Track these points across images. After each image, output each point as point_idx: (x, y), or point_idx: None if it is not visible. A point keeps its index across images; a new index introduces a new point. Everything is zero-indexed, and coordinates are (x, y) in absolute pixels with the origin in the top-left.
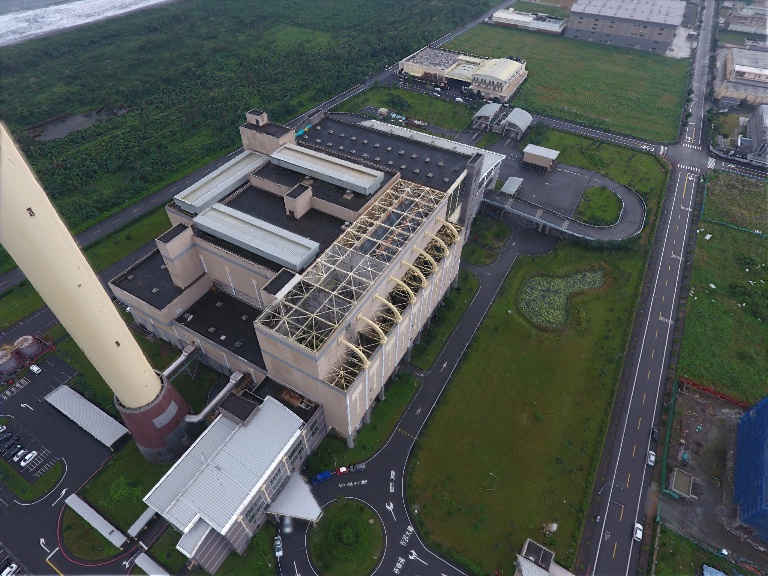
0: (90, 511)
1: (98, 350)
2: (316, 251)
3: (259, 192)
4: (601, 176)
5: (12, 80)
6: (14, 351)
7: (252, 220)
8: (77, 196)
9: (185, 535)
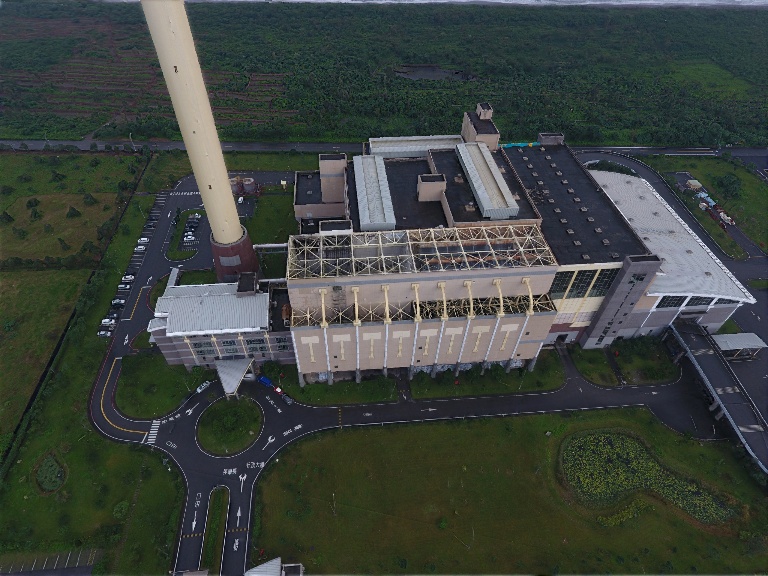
0: (173, 282)
1: (199, 183)
2: (390, 227)
3: (425, 168)
4: None
5: (432, 29)
6: (240, 182)
7: (382, 179)
8: (373, 120)
9: (158, 319)
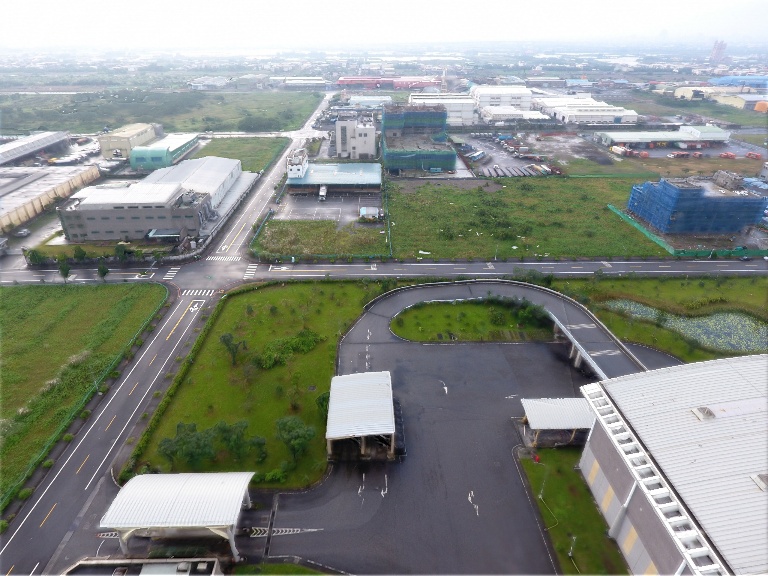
0: None
1: None
2: None
3: None
4: (351, 333)
5: None
6: None
7: None
8: None
9: None
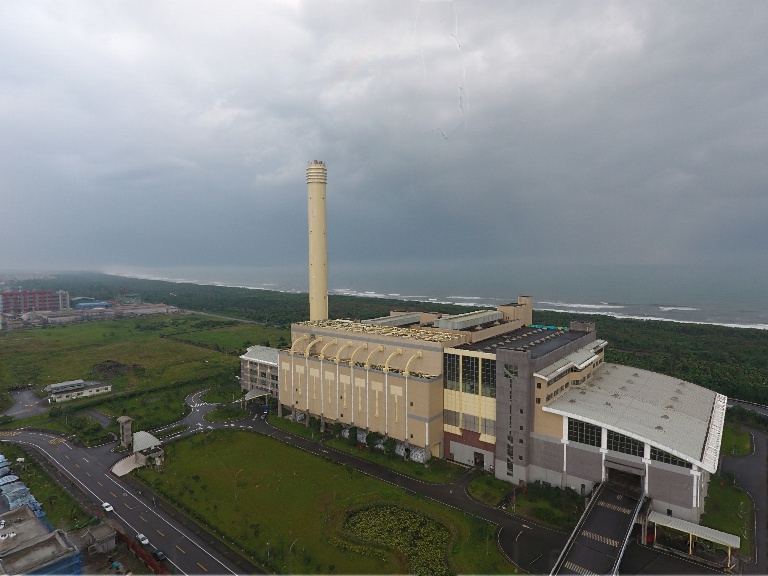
0: None
1: None
2: None
3: None
4: None
5: None
6: None
7: (409, 316)
8: None
9: None
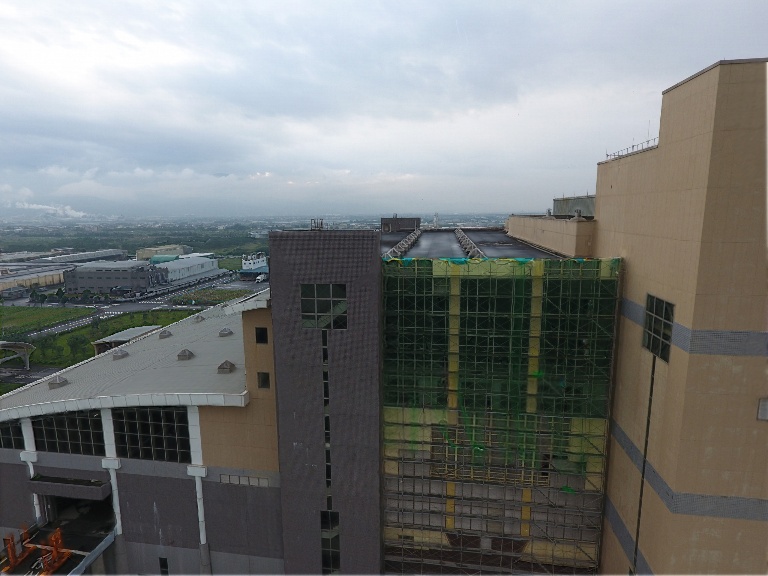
0: None
1: None
2: None
3: None
4: None
5: None
6: None
7: None
8: None
9: None
